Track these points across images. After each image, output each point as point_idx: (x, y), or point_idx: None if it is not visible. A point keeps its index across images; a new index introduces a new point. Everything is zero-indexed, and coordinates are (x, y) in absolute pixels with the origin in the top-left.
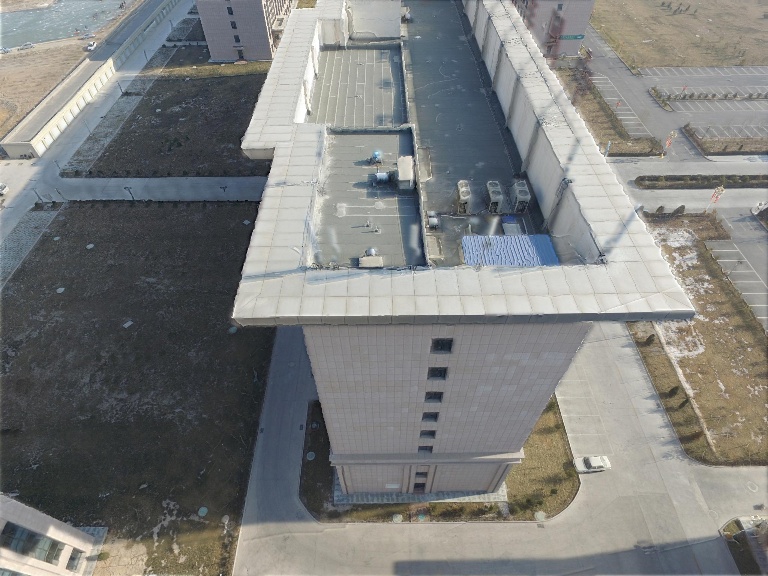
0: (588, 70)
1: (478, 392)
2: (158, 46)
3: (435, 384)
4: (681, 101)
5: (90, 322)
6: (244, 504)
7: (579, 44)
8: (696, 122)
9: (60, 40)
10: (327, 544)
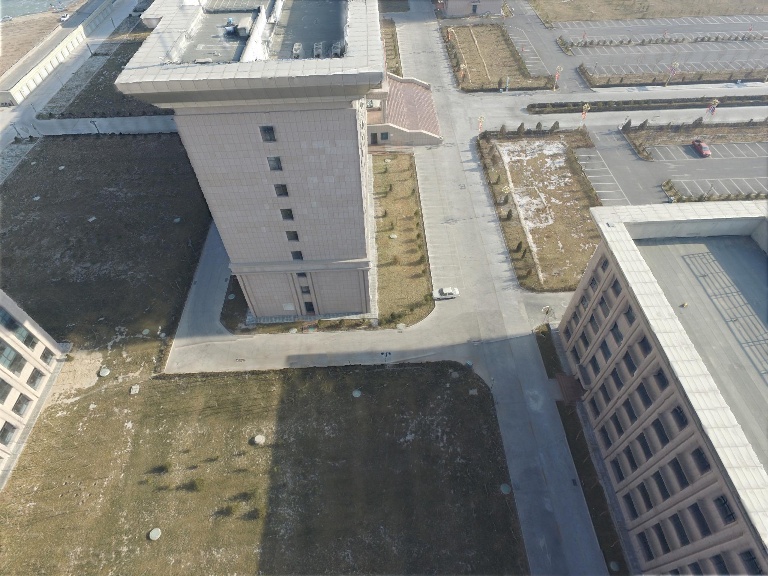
0: (507, 25)
1: (310, 184)
2: (125, 16)
3: (277, 176)
4: (582, 47)
5: (61, 219)
6: (177, 326)
7: (501, 3)
8: (591, 63)
9: (36, 14)
10: (238, 347)
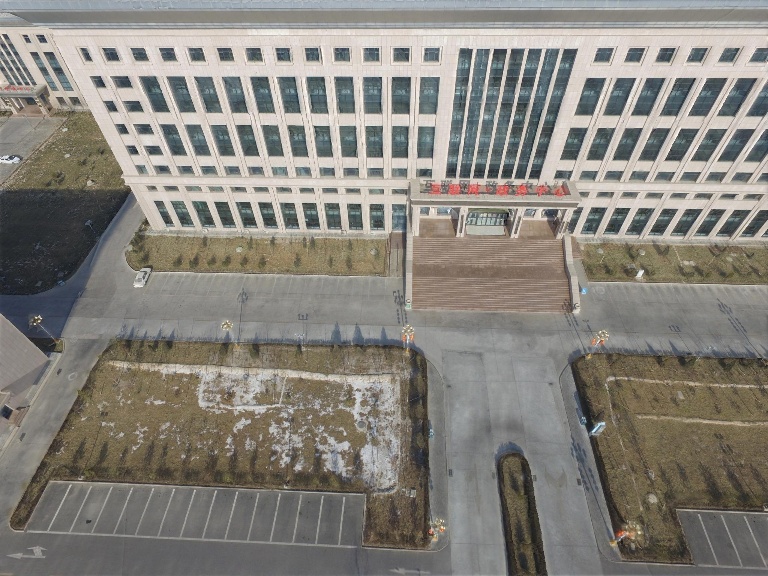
0: None
1: None
2: None
3: None
4: None
5: None
6: None
7: None
8: None
9: None
10: None
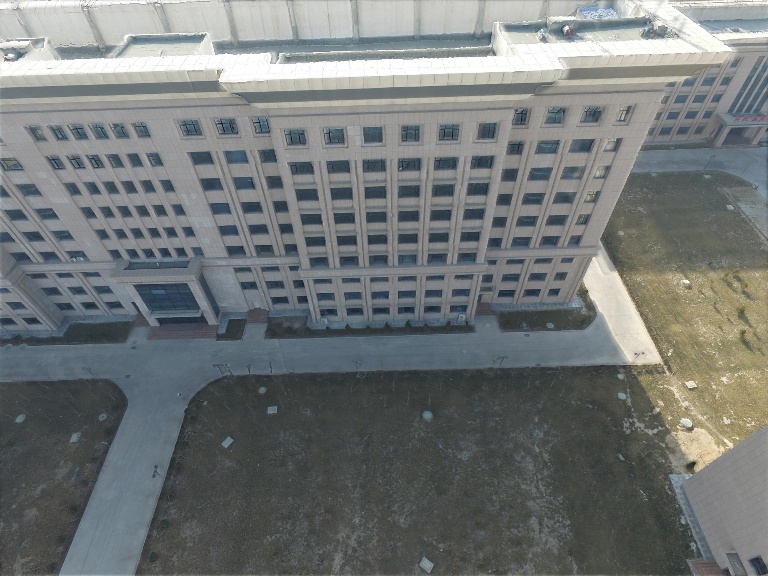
0: None
1: None
2: None
3: None
4: None
5: None
6: None
7: None
8: None
9: None
10: (609, 310)
